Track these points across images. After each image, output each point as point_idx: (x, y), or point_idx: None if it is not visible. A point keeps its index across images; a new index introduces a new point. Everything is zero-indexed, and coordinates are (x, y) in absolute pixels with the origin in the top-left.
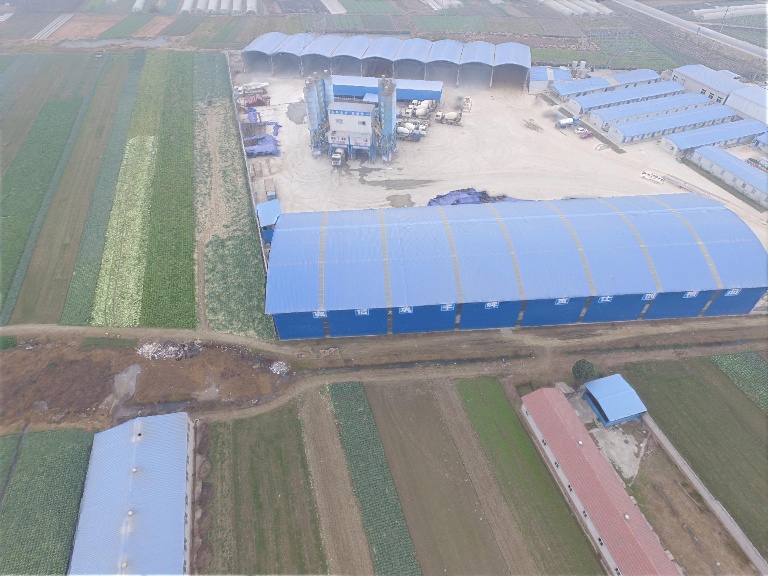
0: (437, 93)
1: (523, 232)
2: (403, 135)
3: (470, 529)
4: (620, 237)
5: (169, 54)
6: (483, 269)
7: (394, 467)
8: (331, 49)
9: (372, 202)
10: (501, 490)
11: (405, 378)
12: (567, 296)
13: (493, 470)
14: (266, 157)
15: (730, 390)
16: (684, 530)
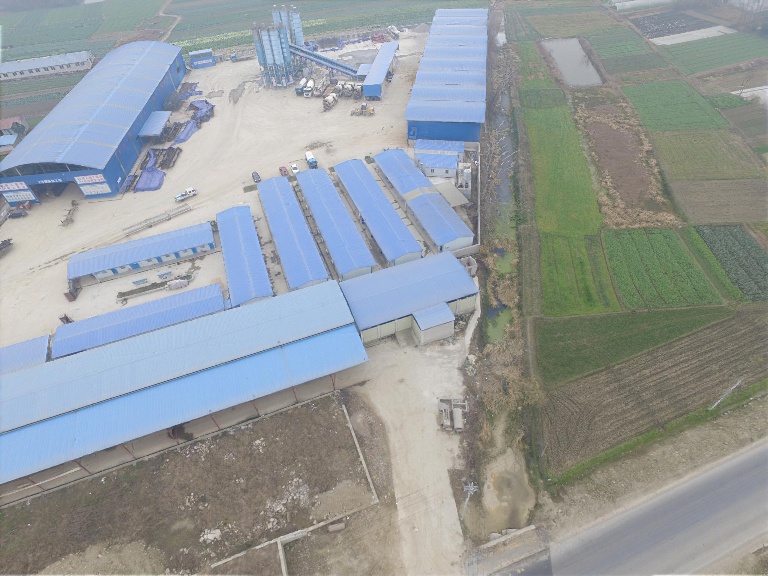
0: None
1: (97, 91)
2: None
3: None
4: None
5: (479, 3)
6: None
7: None
8: (448, 32)
9: (219, 86)
10: None
11: None
12: None
13: None
14: None
15: None
16: None
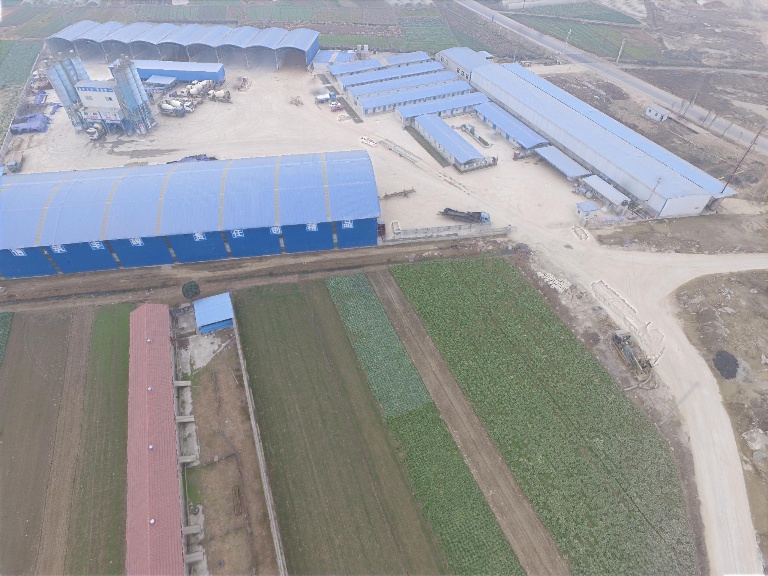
0: (215, 74)
1: (181, 182)
2: (168, 111)
3: (40, 412)
4: (261, 183)
5: None
6: (130, 212)
7: (3, 373)
8: (132, 36)
9: None
10: (85, 384)
11: (54, 307)
12: (197, 232)
13: (87, 370)
14: (32, 133)
15: (324, 302)
16: (215, 401)
